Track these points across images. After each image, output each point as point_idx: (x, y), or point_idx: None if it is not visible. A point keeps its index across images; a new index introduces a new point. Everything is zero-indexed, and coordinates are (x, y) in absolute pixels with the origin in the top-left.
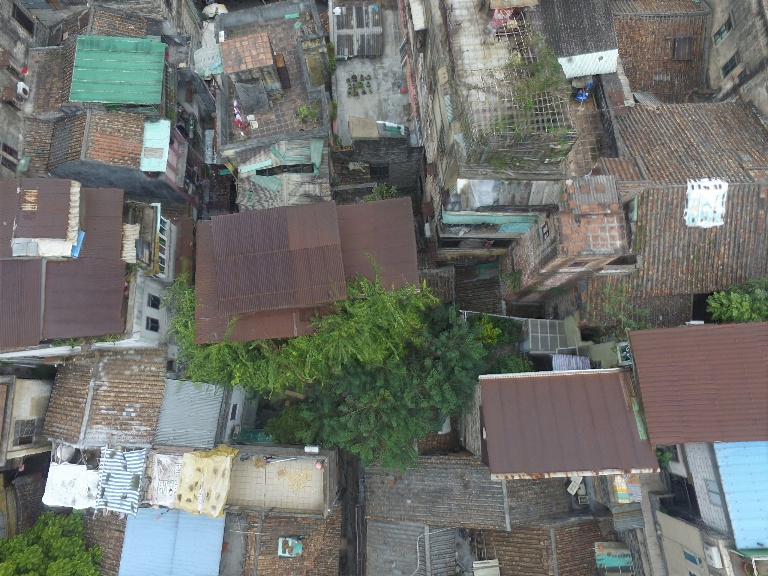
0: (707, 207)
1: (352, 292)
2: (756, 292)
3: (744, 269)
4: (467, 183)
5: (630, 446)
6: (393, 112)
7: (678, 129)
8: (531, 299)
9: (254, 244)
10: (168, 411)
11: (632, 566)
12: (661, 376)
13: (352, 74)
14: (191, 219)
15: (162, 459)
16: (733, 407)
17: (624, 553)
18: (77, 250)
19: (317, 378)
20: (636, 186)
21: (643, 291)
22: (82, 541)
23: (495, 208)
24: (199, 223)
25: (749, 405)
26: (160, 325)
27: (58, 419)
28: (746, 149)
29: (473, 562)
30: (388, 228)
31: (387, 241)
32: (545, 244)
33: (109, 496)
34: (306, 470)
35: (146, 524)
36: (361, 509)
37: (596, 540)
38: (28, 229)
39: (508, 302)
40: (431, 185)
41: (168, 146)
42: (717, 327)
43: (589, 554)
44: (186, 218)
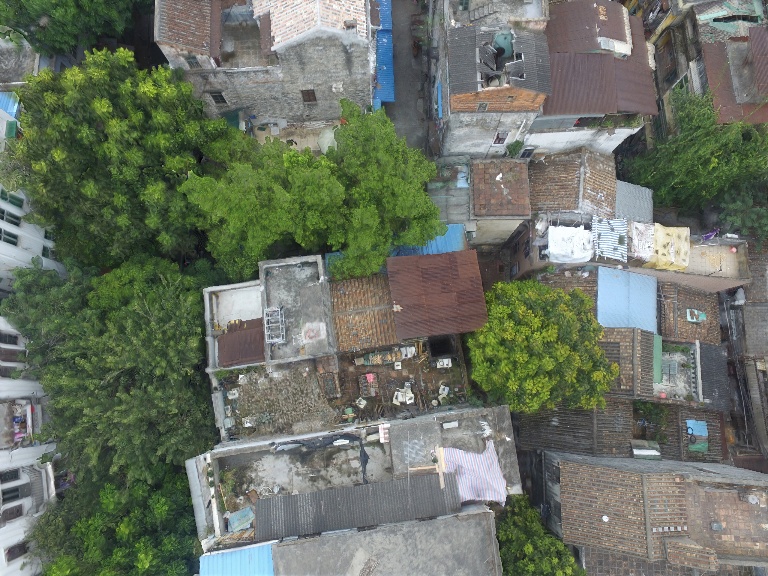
0: None
1: None
2: None
3: None
4: None
5: None
6: None
7: None
8: None
9: None
10: (620, 201)
11: None
12: None
13: None
14: None
15: (638, 226)
16: None
17: None
18: None
19: (762, 173)
20: None
21: None
22: None
23: None
24: (704, 44)
25: None
26: None
27: (544, 199)
28: None
29: None
30: None
31: None
32: None
33: (605, 247)
34: (722, 253)
35: (610, 279)
36: None
37: None
38: (605, 32)
39: None
40: None
41: None
42: None
43: None
44: None
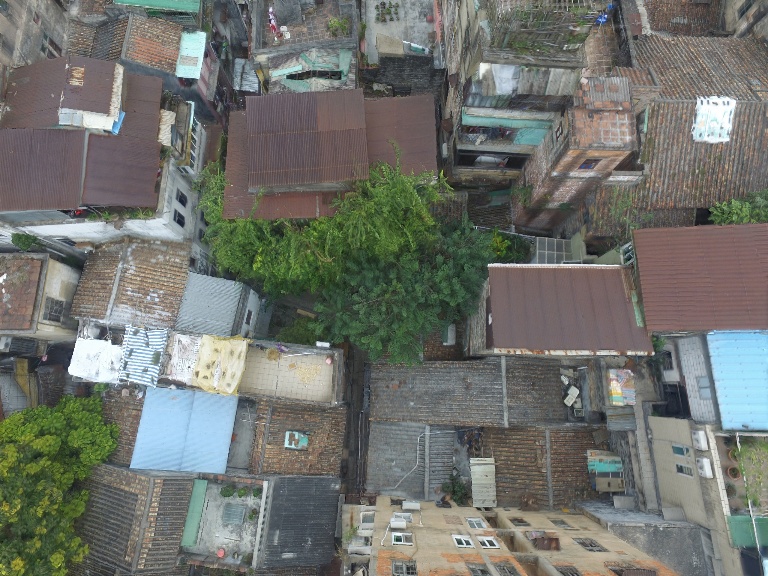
0: (714, 123)
1: (374, 175)
2: (756, 199)
3: (746, 186)
4: (489, 68)
5: (627, 332)
6: (418, 39)
7: (691, 56)
8: (540, 224)
9: (285, 124)
10: (189, 301)
11: (622, 472)
12: (661, 270)
13: (381, 1)
14: (220, 127)
15: (182, 339)
16: (727, 299)
17: (615, 460)
18: (117, 127)
19: (333, 271)
20: (648, 91)
21: (648, 202)
22: (101, 417)
23: (513, 102)
24: None
25: (742, 297)
26: (186, 222)
27: (86, 300)
28: (755, 76)
29: (470, 458)
30: (410, 122)
31: (409, 133)
32: (558, 144)
33: (131, 368)
34: (316, 365)
35: (163, 403)
36: (365, 415)
37: (589, 448)
38: (74, 102)
39: (517, 227)
40: (451, 101)
41: (203, 56)
42: (717, 227)
43: (581, 459)
44: (215, 126)
